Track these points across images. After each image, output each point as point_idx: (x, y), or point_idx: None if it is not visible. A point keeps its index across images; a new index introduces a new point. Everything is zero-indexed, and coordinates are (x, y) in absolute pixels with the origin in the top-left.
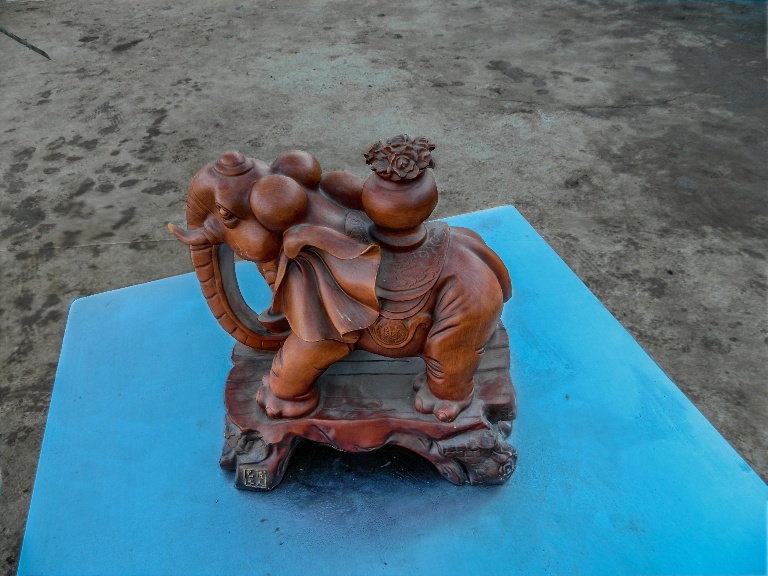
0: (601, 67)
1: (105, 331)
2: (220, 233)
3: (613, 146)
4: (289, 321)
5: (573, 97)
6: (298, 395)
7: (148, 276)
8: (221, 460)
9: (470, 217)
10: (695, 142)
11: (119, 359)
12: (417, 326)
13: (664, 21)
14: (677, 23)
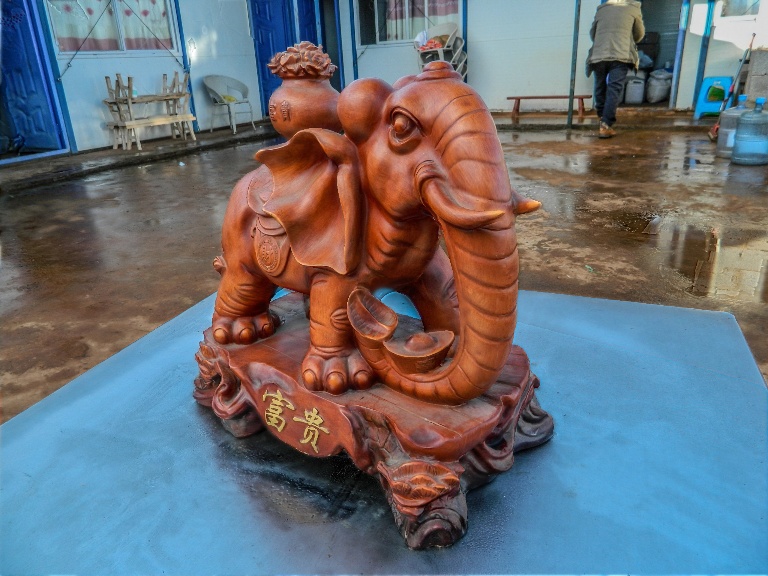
0: None
1: None
2: None
3: None
4: None
5: None
6: None
7: None
8: None
9: None
10: None
11: None
12: None
13: None
14: None
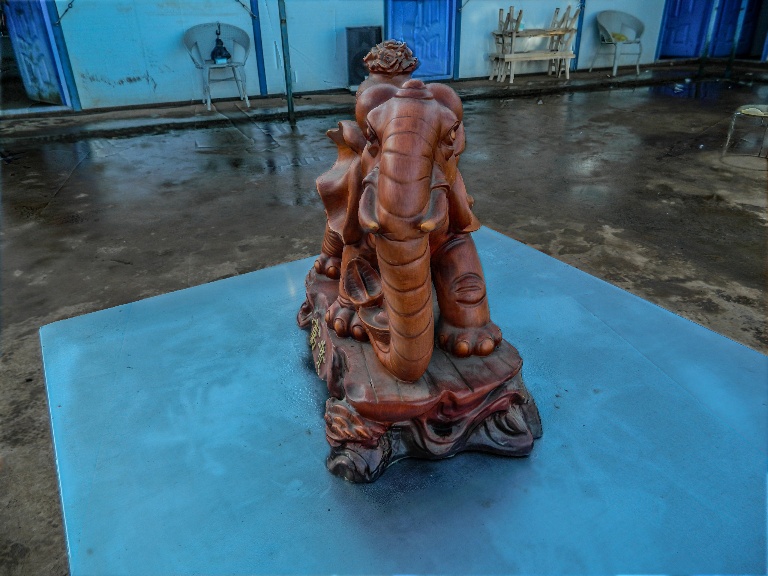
0: None
1: None
2: None
3: None
4: (469, 227)
5: None
6: None
7: None
8: None
9: (57, 351)
10: None
11: None
12: None
13: None
14: None
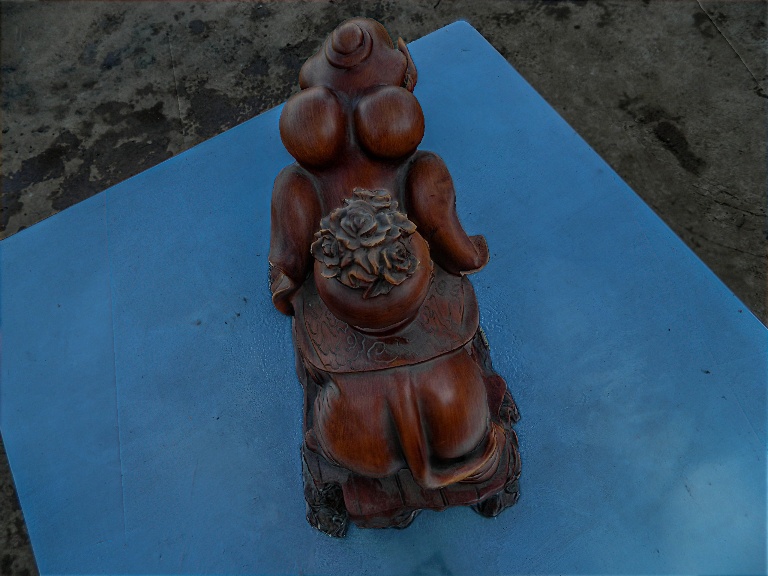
0: None
1: (428, 69)
2: None
3: None
4: None
5: None
6: None
7: (658, 58)
8: None
9: None
10: None
11: None
12: None
13: None
14: None
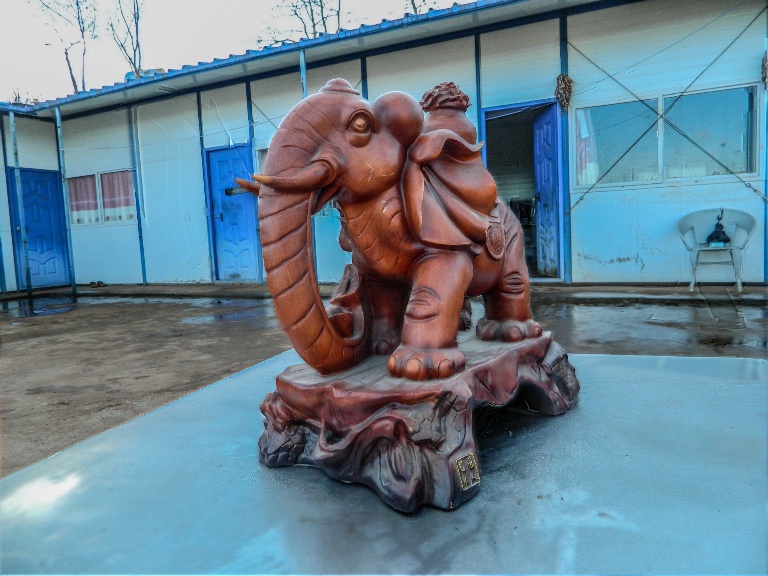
0: (150, 368)
1: None
2: (342, 160)
3: None
4: (434, 238)
5: (149, 386)
6: None
7: None
8: (412, 486)
9: (276, 358)
10: None
11: (27, 572)
12: (504, 234)
13: (169, 338)
14: (180, 338)
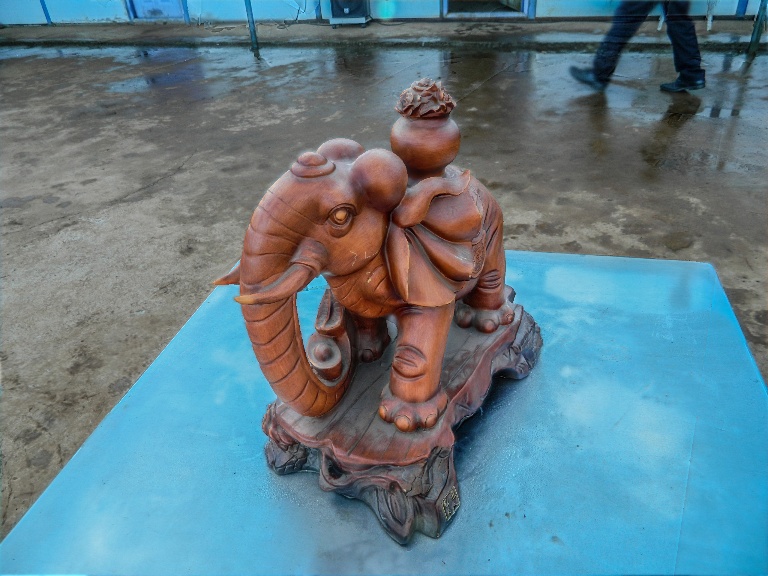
0: (93, 167)
1: None
2: (325, 254)
3: (182, 212)
4: (420, 302)
5: (100, 196)
6: (439, 382)
7: None
8: (407, 529)
9: None
10: (234, 183)
11: None
12: (485, 243)
13: (102, 119)
14: (115, 117)
